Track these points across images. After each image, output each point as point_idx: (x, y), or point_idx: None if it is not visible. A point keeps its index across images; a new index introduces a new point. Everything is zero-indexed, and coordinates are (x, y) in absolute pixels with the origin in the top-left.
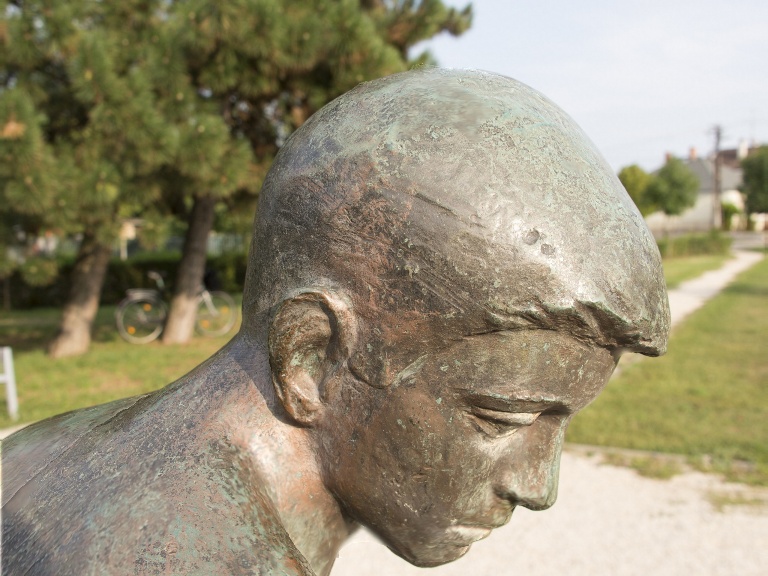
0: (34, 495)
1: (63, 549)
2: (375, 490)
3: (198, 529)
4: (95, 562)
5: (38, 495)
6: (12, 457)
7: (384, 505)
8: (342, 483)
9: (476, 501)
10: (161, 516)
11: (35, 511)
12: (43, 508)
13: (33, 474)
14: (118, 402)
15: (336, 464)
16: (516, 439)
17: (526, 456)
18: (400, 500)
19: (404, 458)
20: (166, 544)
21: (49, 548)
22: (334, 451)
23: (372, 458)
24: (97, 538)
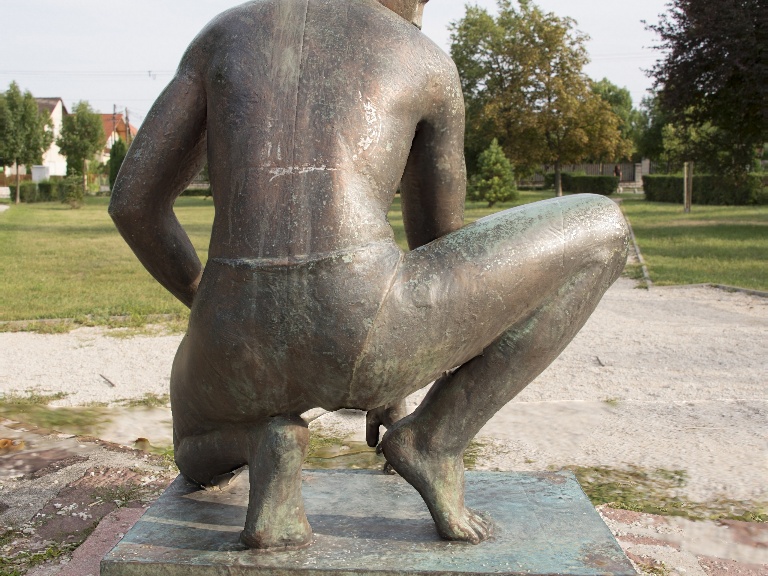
0: (318, 2)
1: (356, 6)
2: None
3: None
4: None
5: None
6: None
7: None
8: None
9: None
10: (373, 2)
11: (326, 4)
12: (329, 3)
13: None
14: None
15: (385, 6)
16: (417, 8)
17: None
18: None
19: (406, 3)
20: None
21: (349, 7)
22: (385, 1)
23: (397, 3)
24: None
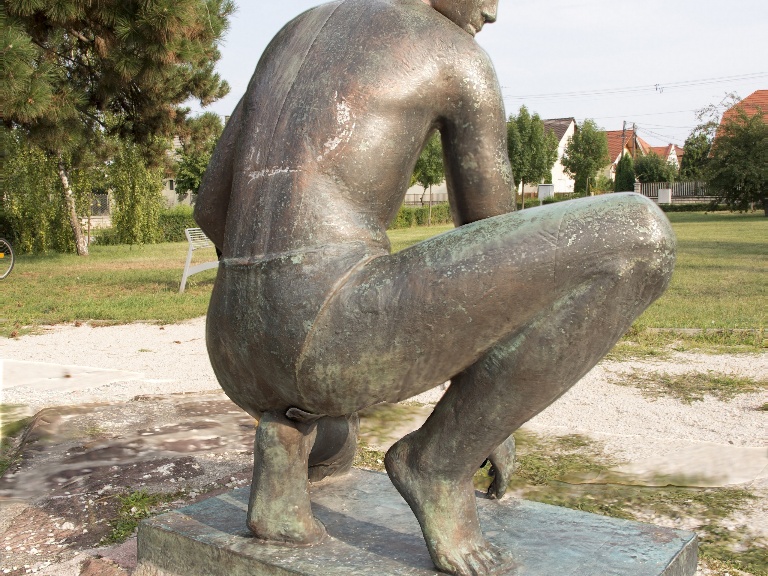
0: None
1: (374, 5)
2: (450, 7)
3: (412, 0)
4: (389, 3)
5: (348, 5)
6: (324, 4)
7: (452, 12)
8: (439, 6)
9: (476, 15)
10: None
11: None
12: (354, 5)
13: (339, 4)
14: None
15: None
16: None
17: (490, 3)
18: (457, 10)
19: None
20: (406, 1)
21: (367, 7)
22: None
23: None
24: (385, 1)
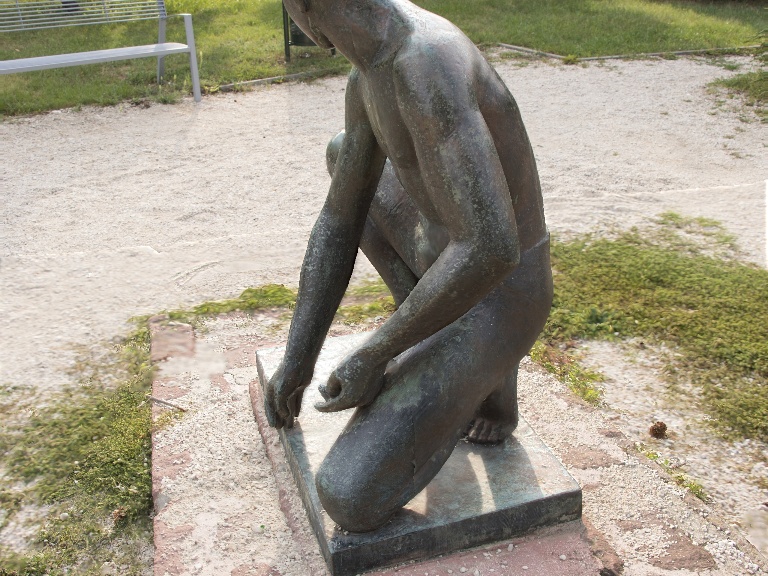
0: None
1: None
2: None
3: None
4: None
5: None
6: None
7: None
8: None
9: None
10: None
11: None
12: None
13: None
14: (412, 8)
15: None
16: None
17: None
18: None
19: None
20: None
21: None
22: None
23: None
24: None
